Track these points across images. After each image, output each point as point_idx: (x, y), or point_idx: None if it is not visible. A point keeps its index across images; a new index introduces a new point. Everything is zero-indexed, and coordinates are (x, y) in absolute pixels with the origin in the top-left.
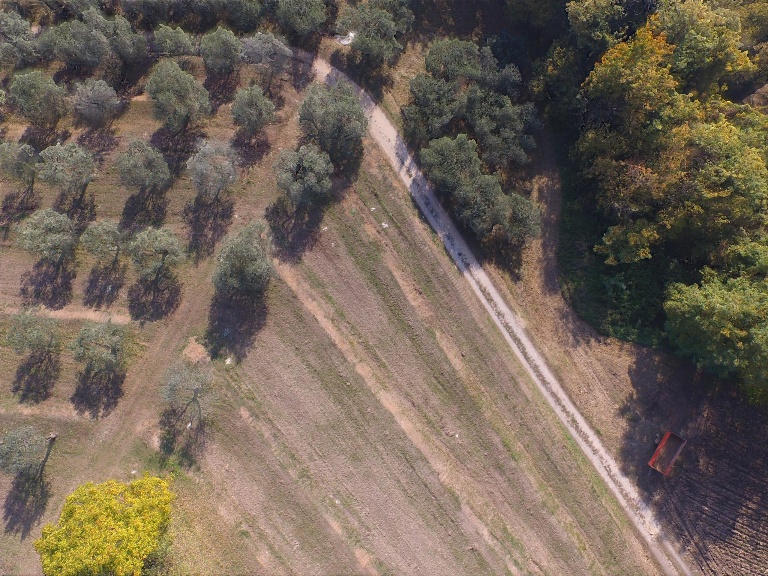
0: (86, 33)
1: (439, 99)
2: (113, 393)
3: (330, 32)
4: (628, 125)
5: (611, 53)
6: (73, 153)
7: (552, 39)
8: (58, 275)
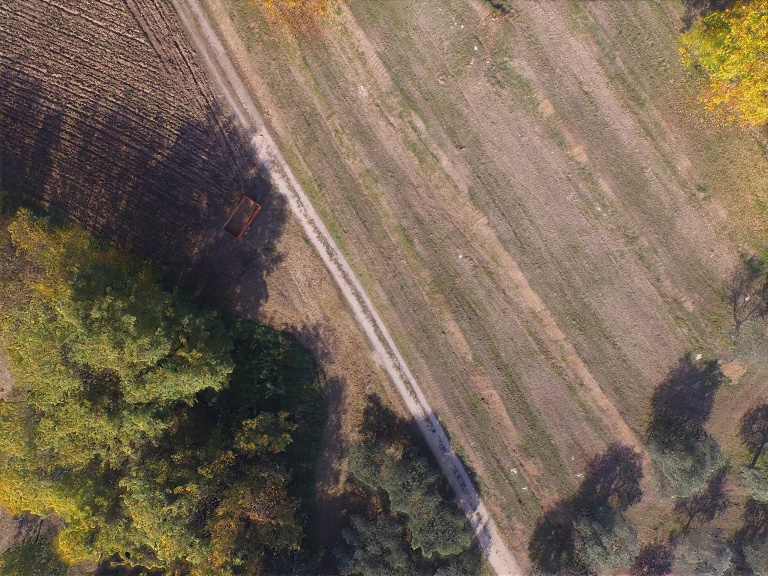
0: None
1: None
2: None
3: None
4: None
5: None
6: None
7: None
8: None
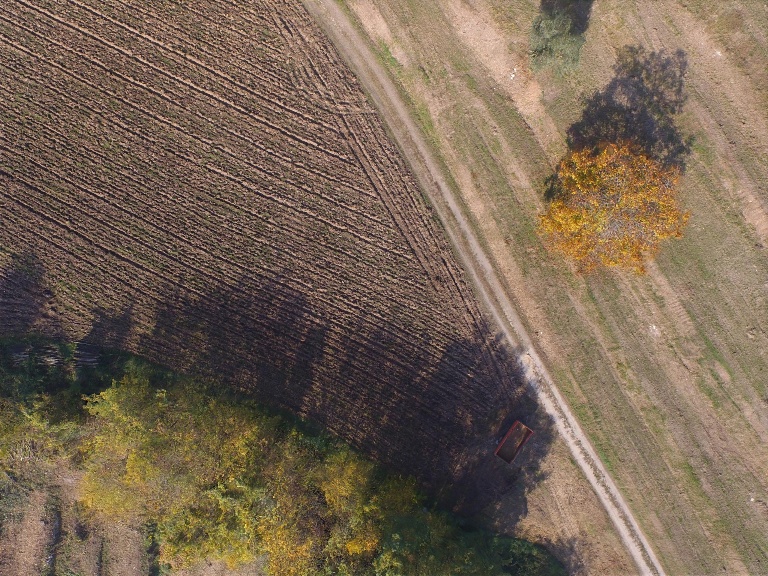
0: None
1: None
2: None
3: None
4: None
5: None
6: None
7: None
8: None
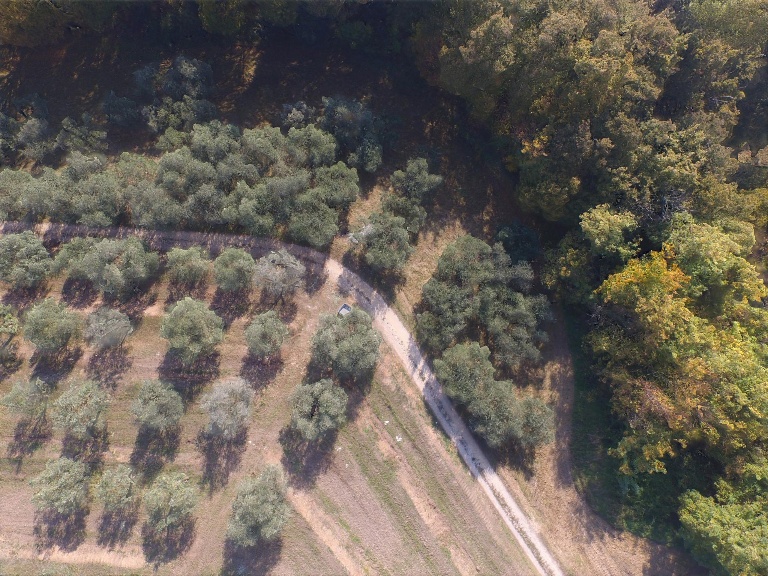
0: (99, 265)
1: (452, 307)
2: None
3: (342, 230)
4: (642, 338)
5: (626, 276)
6: (87, 400)
7: (564, 231)
8: (71, 512)
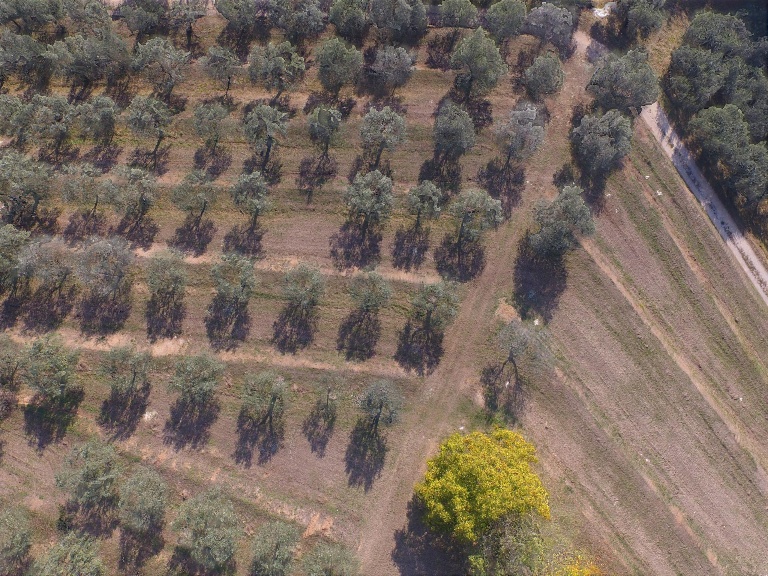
0: (389, 1)
1: (707, 70)
2: (434, 352)
3: (587, 5)
4: None
5: None
6: None
7: None
8: (365, 238)
